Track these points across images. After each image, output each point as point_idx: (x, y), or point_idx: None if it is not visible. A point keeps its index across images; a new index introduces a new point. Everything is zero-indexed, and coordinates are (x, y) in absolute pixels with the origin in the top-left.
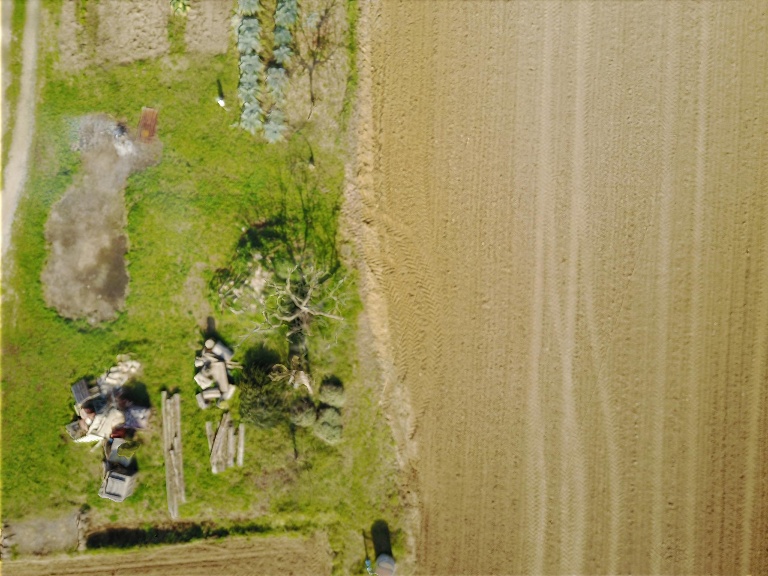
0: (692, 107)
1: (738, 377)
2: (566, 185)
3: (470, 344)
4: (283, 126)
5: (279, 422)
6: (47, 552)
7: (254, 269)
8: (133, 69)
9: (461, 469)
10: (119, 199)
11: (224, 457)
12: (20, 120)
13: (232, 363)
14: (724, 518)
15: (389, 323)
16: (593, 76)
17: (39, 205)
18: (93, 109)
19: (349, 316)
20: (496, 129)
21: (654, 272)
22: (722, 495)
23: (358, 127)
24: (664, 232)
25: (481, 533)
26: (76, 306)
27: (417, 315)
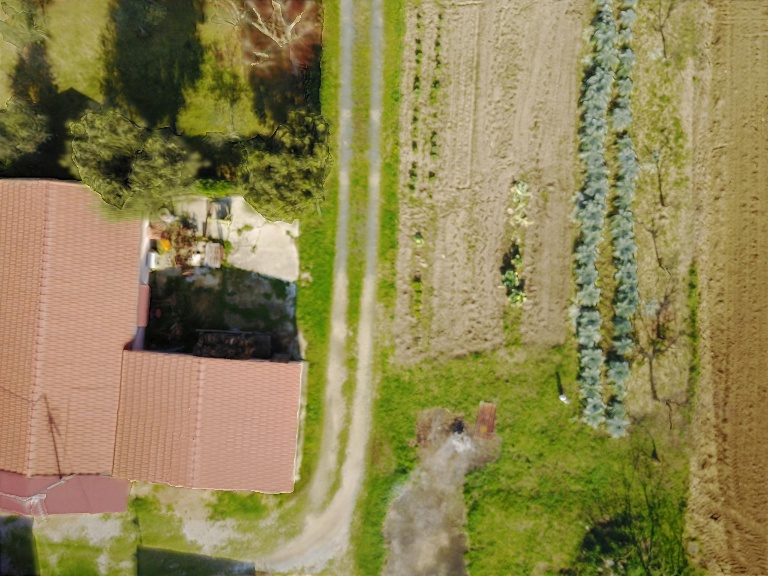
0: None
1: None
2: None
3: None
4: (627, 421)
5: None
6: None
7: (606, 575)
8: (470, 362)
9: None
10: (458, 496)
11: None
12: (357, 416)
13: None
14: None
15: None
16: None
17: (378, 503)
18: (430, 404)
19: None
20: None
21: None
22: None
23: (701, 417)
24: None
25: None
26: None
27: None
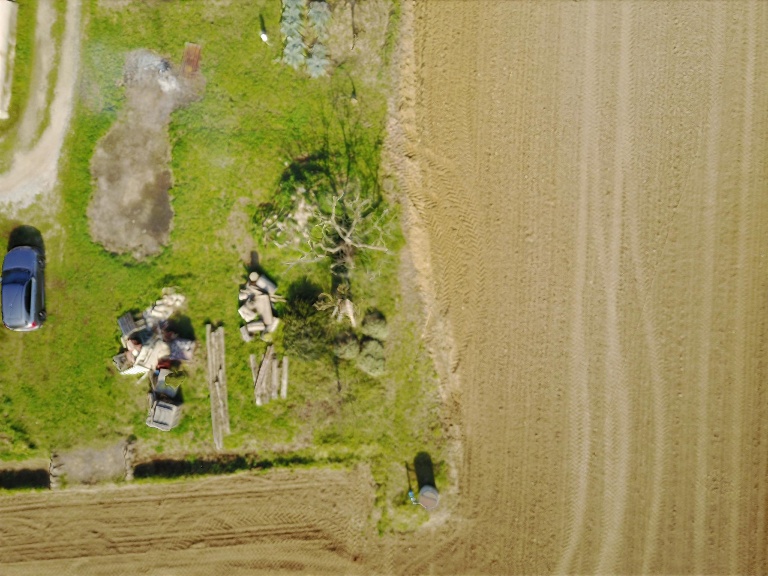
0: (740, 36)
1: None
2: (611, 117)
3: (513, 278)
4: (325, 60)
5: (323, 355)
6: (95, 481)
7: (297, 202)
8: (176, 4)
9: (504, 402)
10: (163, 134)
11: (268, 389)
12: (65, 56)
13: (276, 296)
14: None
15: (431, 257)
16: (638, 6)
17: (85, 140)
18: (137, 45)
19: (391, 250)
20: (539, 61)
21: (700, 204)
22: None
23: (400, 61)
24: (710, 164)
25: (524, 465)
26: (122, 240)
27: (460, 249)
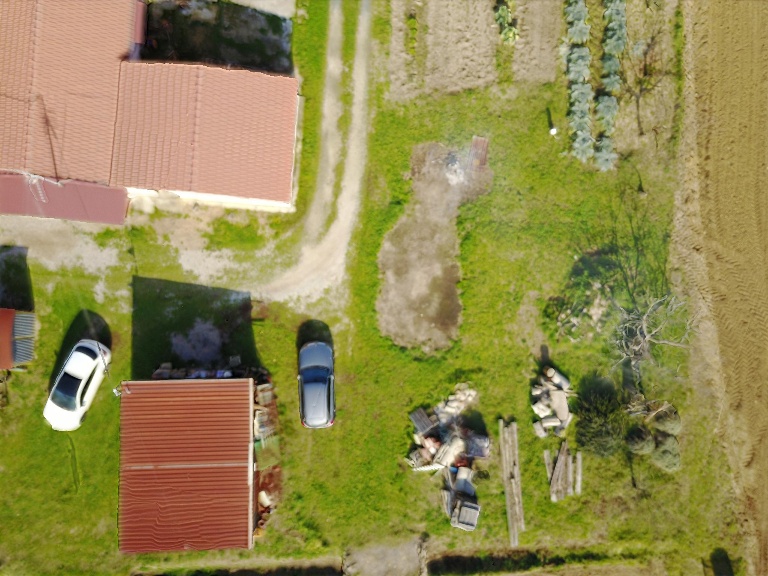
0: None
1: None
2: None
3: None
4: (615, 154)
5: (617, 450)
6: None
7: (593, 297)
8: (463, 98)
9: None
10: (451, 228)
11: (563, 485)
12: (352, 150)
13: (568, 391)
14: None
15: (720, 350)
16: None
17: (373, 234)
18: (424, 138)
19: None
20: None
21: None
22: None
23: (685, 154)
24: None
25: None
26: (410, 334)
27: (751, 342)
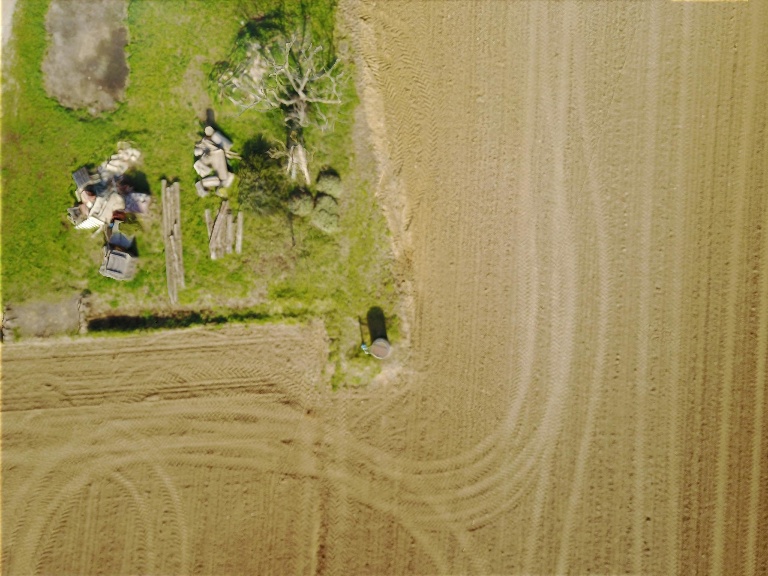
0: None
1: (724, 168)
2: None
3: (464, 137)
4: None
5: (277, 210)
6: (49, 334)
7: (253, 58)
8: None
9: (455, 258)
10: None
11: (223, 244)
12: None
13: (231, 153)
14: (709, 303)
15: (385, 118)
16: None
17: None
18: None
19: (346, 110)
20: None
21: (644, 66)
22: (708, 281)
23: None
24: (654, 27)
25: (474, 319)
26: (77, 96)
27: (413, 109)
